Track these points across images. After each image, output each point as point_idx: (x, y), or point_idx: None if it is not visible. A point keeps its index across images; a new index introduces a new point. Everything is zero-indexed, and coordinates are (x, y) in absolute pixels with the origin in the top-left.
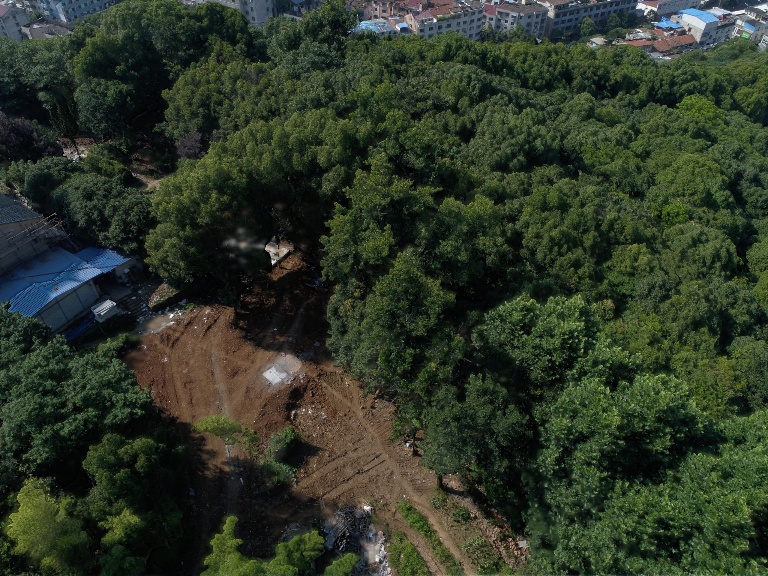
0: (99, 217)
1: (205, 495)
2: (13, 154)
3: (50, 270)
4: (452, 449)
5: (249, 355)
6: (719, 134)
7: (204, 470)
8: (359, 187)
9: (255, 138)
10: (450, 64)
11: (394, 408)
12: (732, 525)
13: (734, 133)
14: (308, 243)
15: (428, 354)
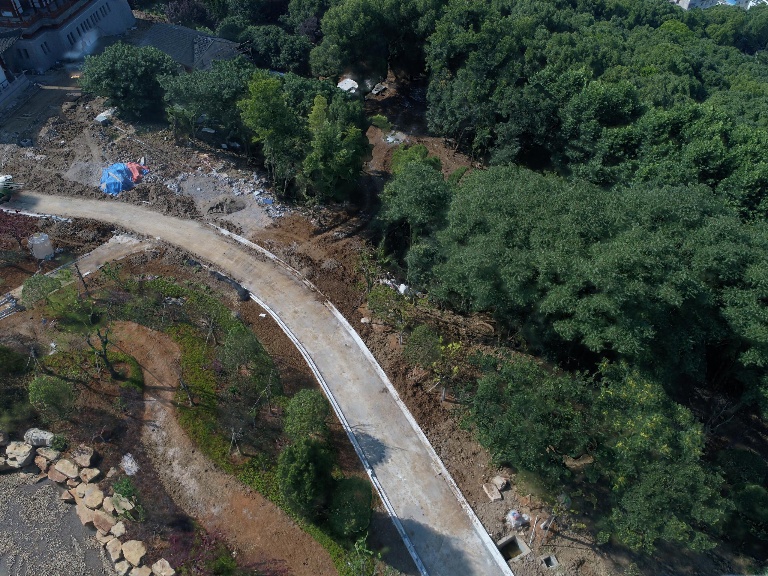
0: (274, 47)
1: (363, 182)
2: (194, 24)
3: None
4: (515, 122)
5: (373, 131)
6: (689, 45)
7: (359, 173)
8: (453, 5)
9: None
10: None
11: (467, 157)
12: (660, 128)
13: (700, 44)
14: (405, 70)
15: (500, 80)
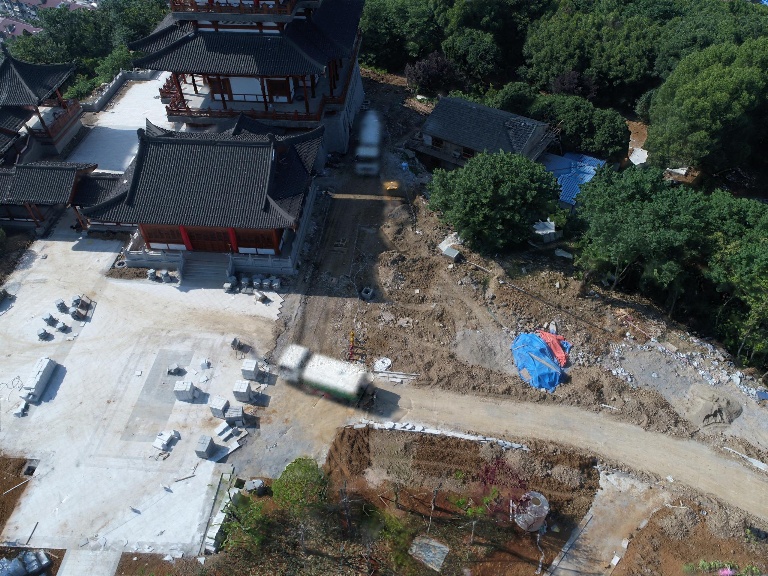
0: (587, 126)
1: None
2: (443, 87)
3: (561, 166)
4: None
5: None
6: None
7: None
8: None
9: (719, 59)
10: (755, 16)
11: None
12: None
13: None
14: None
15: None
